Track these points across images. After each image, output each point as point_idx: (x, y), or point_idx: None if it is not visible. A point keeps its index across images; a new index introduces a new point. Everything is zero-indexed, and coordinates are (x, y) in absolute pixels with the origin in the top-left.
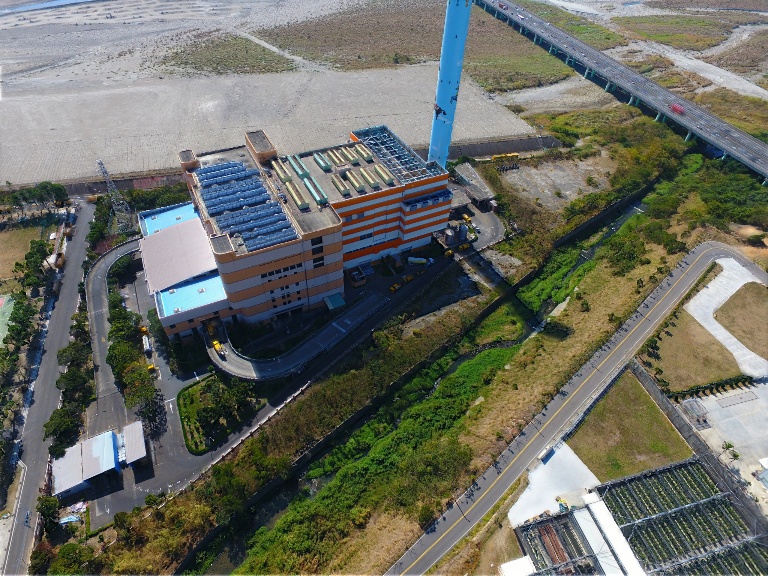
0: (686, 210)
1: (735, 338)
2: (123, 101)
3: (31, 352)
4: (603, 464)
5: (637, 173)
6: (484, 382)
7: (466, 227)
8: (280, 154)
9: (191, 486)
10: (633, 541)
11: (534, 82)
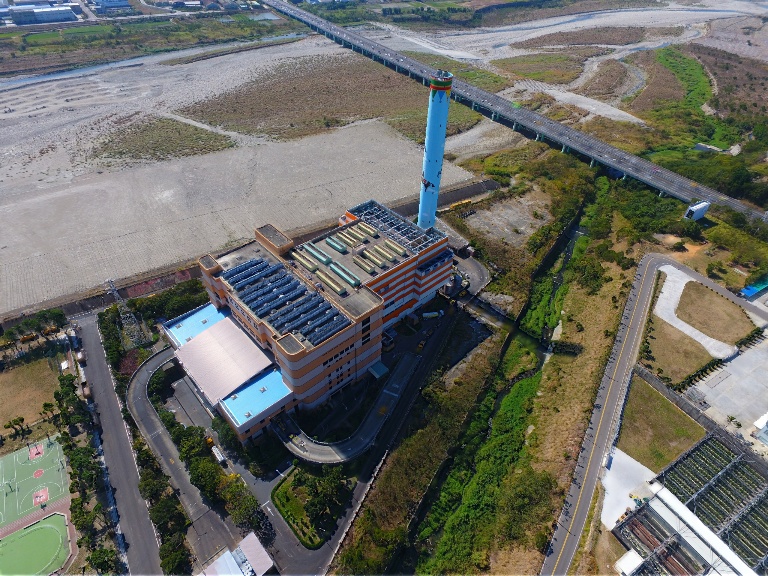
0: (617, 228)
1: (697, 330)
2: (71, 204)
3: (100, 494)
4: (650, 457)
5: (569, 202)
6: (527, 412)
7: (460, 276)
8: None
9: None
10: (696, 513)
11: (454, 130)
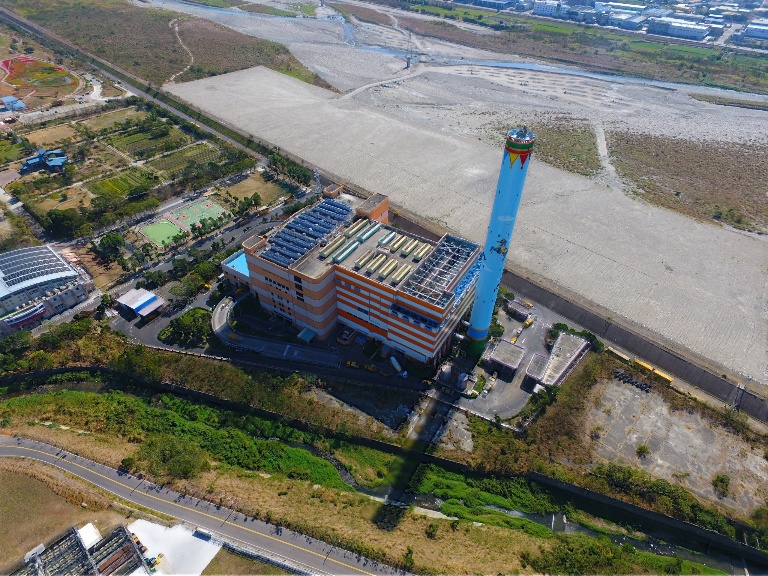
0: None
1: None
2: (431, 144)
3: (197, 242)
4: None
5: None
6: (289, 473)
7: (465, 377)
8: (457, 230)
9: (137, 346)
10: None
11: None
